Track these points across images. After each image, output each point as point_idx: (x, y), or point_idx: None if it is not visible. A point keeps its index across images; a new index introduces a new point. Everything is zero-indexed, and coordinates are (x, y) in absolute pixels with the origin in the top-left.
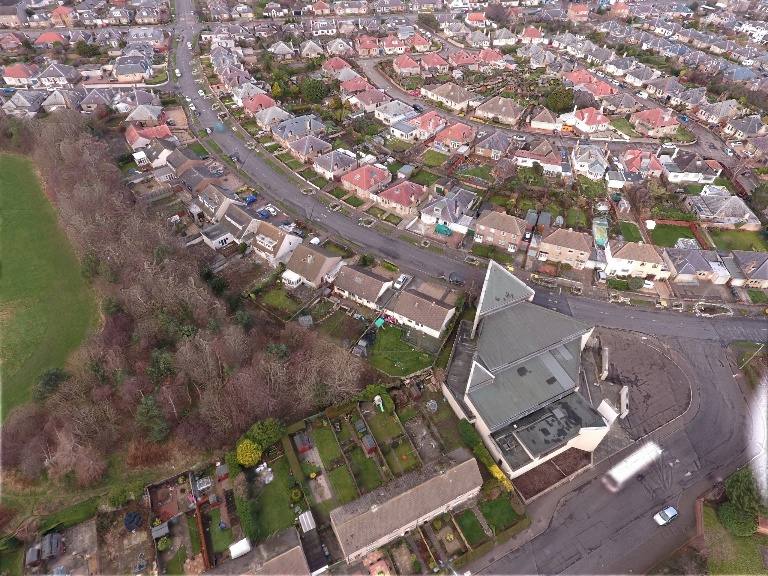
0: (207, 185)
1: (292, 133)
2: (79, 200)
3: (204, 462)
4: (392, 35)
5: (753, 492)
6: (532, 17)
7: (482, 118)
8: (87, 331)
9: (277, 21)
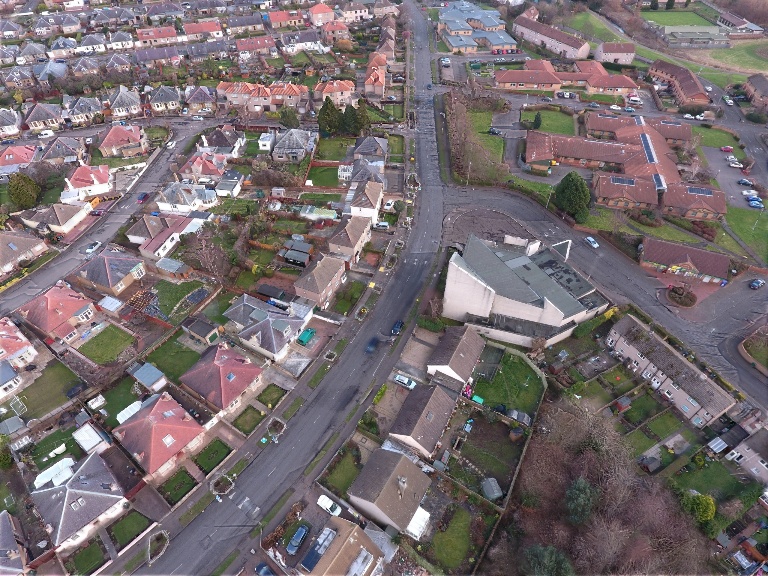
0: None
1: None
2: None
3: (725, 567)
4: None
5: (583, 197)
6: None
7: (2, 280)
8: None
9: None
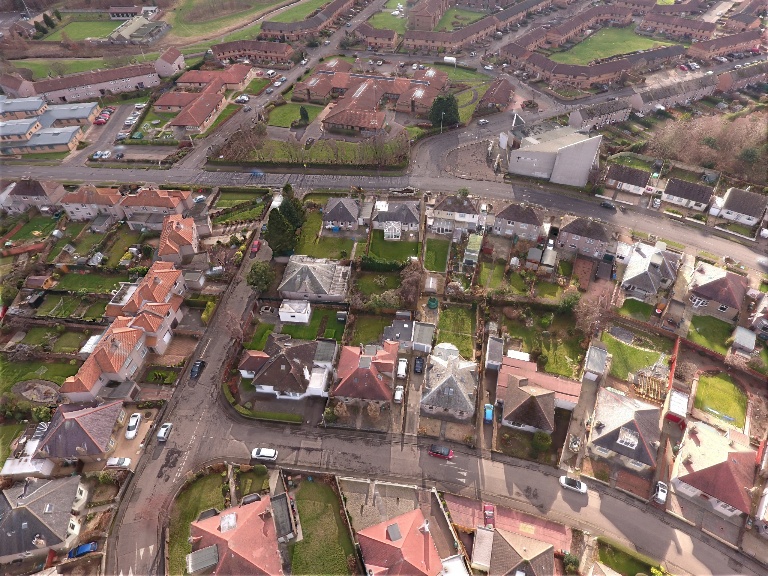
0: None
1: None
2: None
3: None
4: None
5: None
6: None
7: None
8: None
9: None
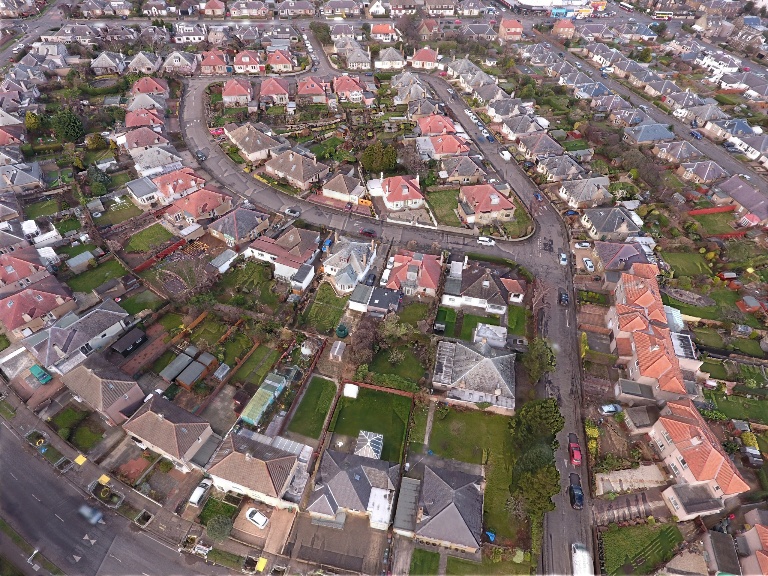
0: None
1: None
2: None
3: None
4: (245, 50)
5: None
6: (453, 32)
7: (272, 176)
8: None
9: None
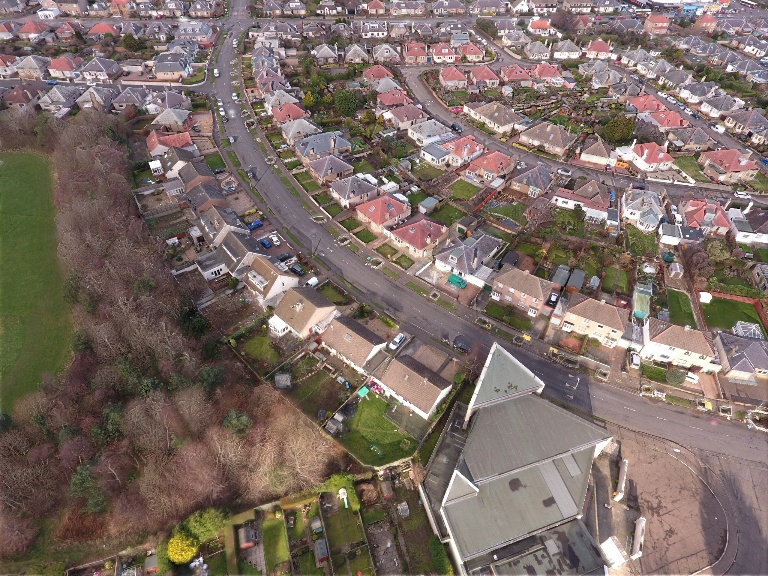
0: (210, 207)
1: (314, 150)
2: (77, 215)
3: (135, 548)
4: (443, 42)
5: None
6: (603, 27)
7: (526, 145)
8: (57, 364)
9: (329, 19)
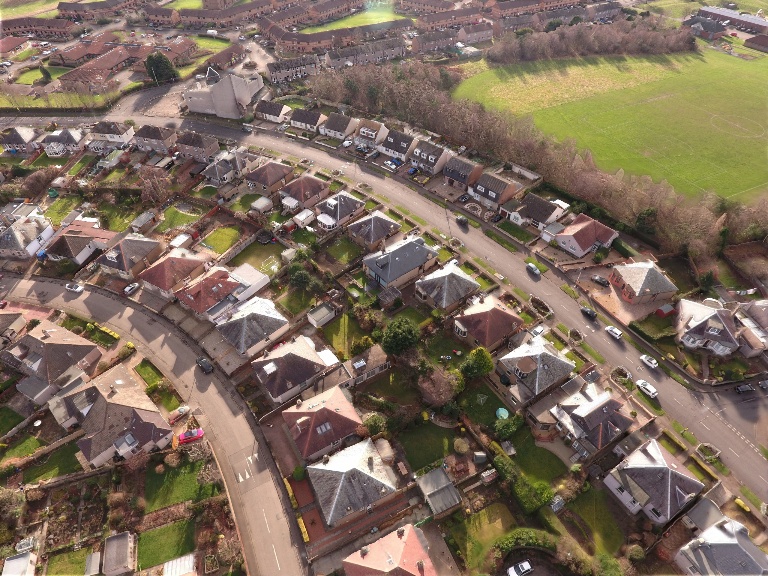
0: (445, 149)
1: None
2: None
3: None
4: None
5: None
6: None
7: None
8: None
9: None
